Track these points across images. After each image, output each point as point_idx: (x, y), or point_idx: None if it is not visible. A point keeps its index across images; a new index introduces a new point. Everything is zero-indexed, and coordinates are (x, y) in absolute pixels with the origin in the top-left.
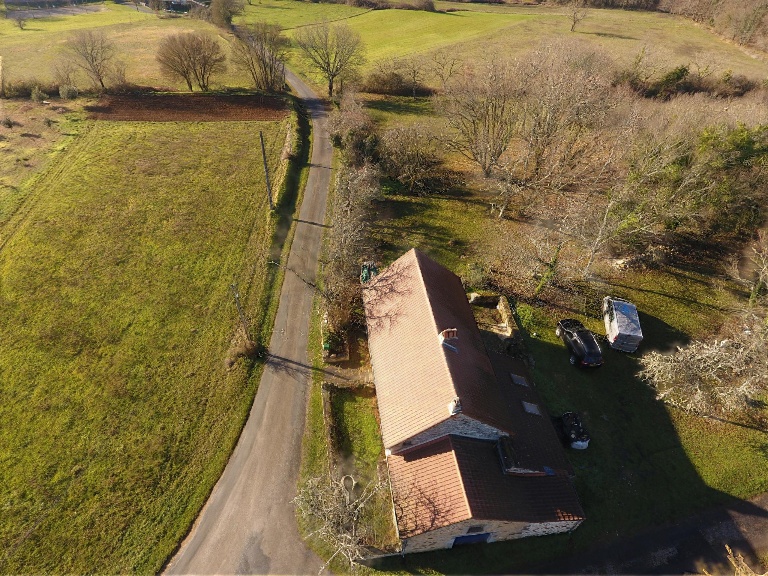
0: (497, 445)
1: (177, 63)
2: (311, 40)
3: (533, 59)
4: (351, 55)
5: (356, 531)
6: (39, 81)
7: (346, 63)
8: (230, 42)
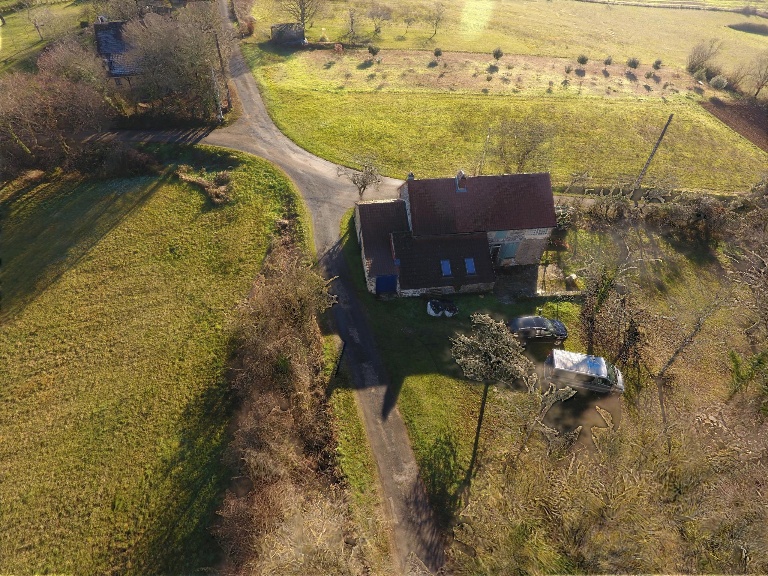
0: None
1: None
2: None
3: None
4: None
5: None
6: (722, 70)
7: None
8: None
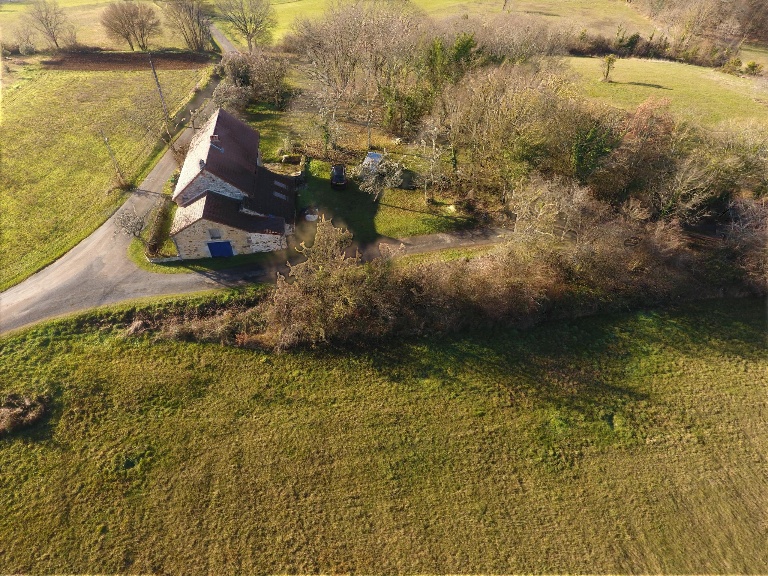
0: (241, 202)
1: (119, 27)
2: (229, 6)
3: (353, 2)
4: (265, 19)
5: (158, 251)
6: (4, 42)
7: (260, 25)
8: (163, 8)
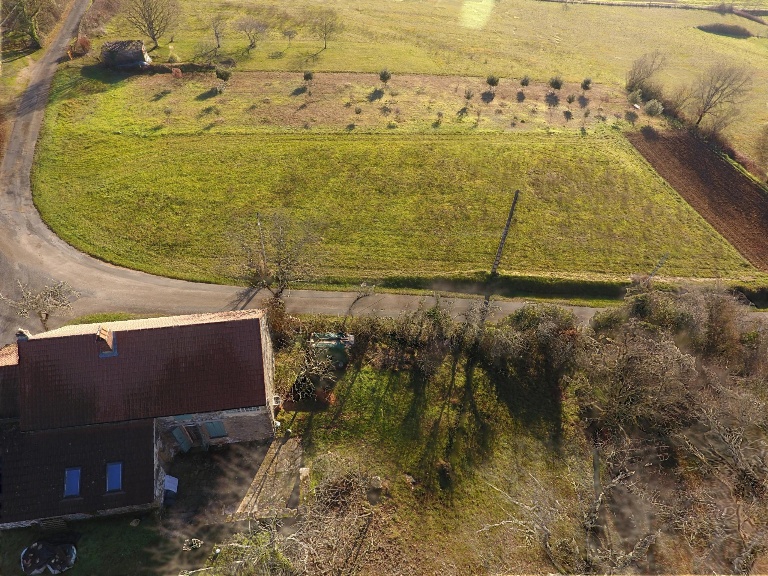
0: None
1: None
2: None
3: None
4: None
5: None
6: (663, 90)
7: None
8: None
